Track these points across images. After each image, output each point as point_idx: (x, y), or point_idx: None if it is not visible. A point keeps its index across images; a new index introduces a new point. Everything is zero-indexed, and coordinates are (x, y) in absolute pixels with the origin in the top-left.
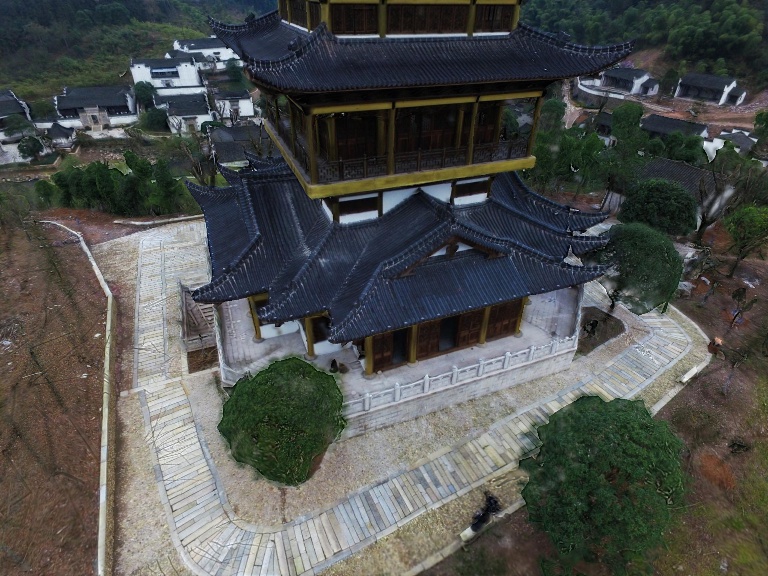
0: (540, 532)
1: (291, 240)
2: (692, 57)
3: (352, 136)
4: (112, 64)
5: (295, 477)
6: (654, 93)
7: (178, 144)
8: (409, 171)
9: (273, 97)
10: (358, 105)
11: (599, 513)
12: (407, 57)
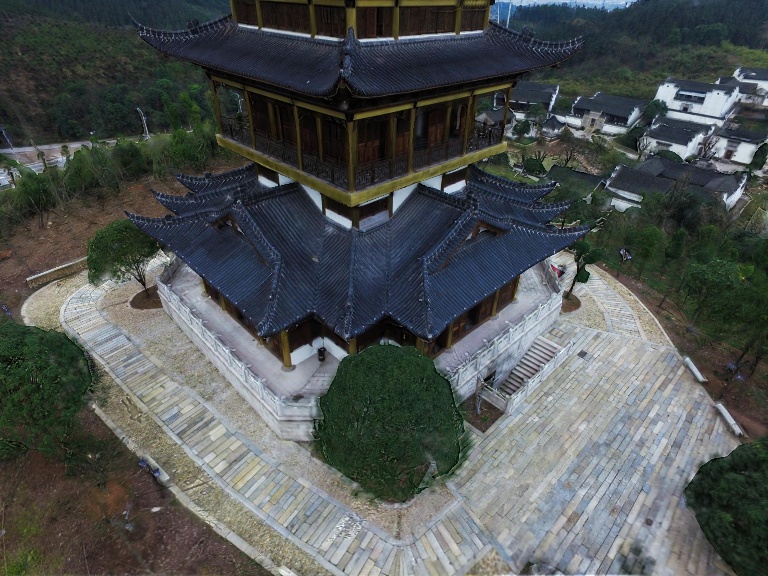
0: None
1: None
2: None
3: (258, 110)
4: (661, 80)
5: (91, 278)
6: None
7: (614, 160)
8: (265, 153)
9: (165, 56)
10: (227, 80)
11: None
12: (253, 47)
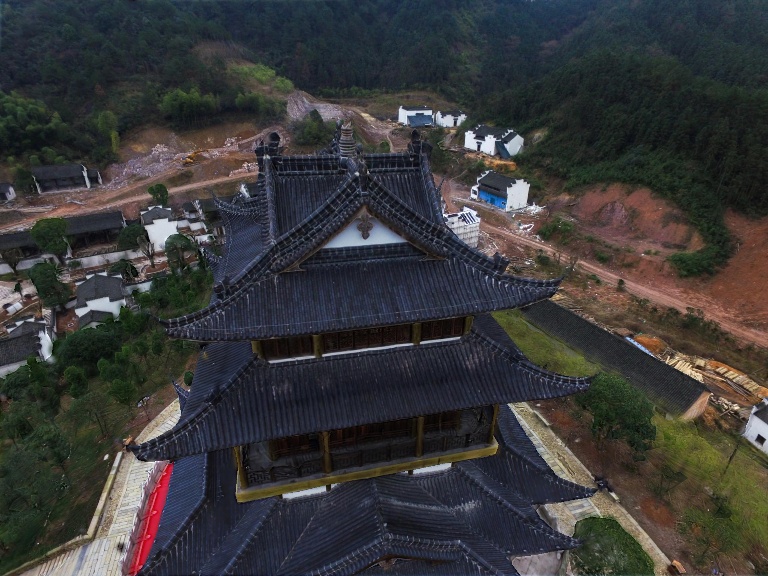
0: (600, 463)
1: (447, 519)
2: (11, 151)
3: None
4: None
5: None
6: (13, 196)
7: None
8: None
9: None
10: None
11: (647, 414)
12: None
